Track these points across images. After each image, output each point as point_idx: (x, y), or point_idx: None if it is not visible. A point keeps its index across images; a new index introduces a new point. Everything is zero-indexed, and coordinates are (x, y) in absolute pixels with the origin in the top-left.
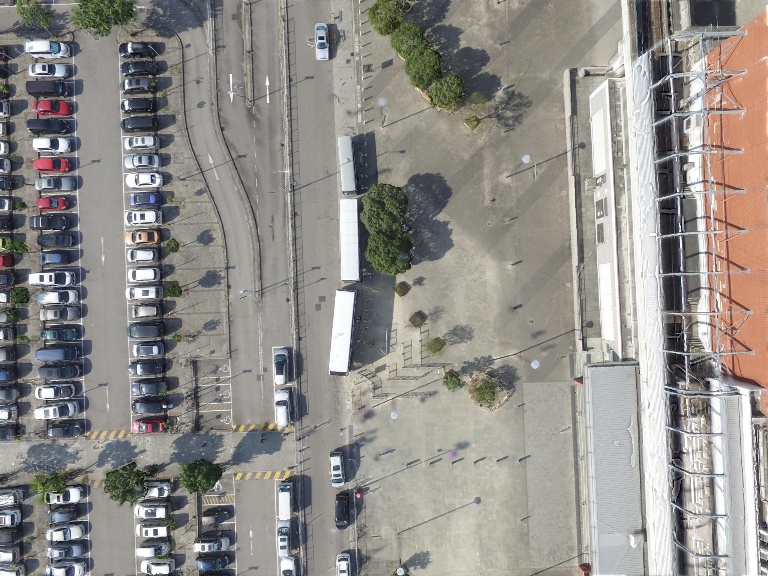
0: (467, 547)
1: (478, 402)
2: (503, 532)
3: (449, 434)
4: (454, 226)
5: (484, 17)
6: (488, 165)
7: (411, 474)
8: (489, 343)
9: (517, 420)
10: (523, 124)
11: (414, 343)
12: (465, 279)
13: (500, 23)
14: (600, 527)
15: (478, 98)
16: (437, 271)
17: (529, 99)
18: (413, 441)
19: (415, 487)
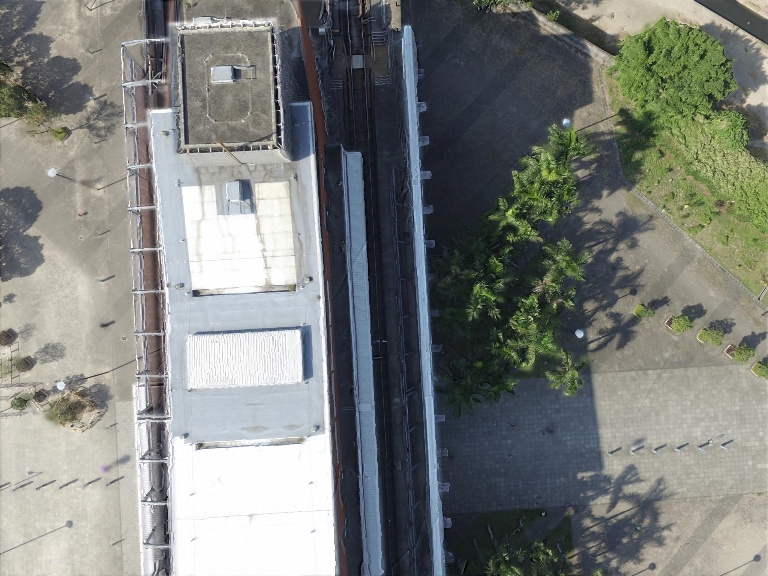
0: (59, 573)
1: (70, 422)
2: (96, 557)
3: (40, 456)
4: (45, 241)
5: (76, 25)
6: (80, 177)
7: (1, 498)
8: (81, 361)
9: (110, 440)
10: (115, 134)
11: (4, 362)
12: (56, 295)
13: (92, 31)
14: (147, 553)
15: (69, 108)
16: (28, 288)
17: (122, 109)
18: (3, 464)
19: (5, 511)
